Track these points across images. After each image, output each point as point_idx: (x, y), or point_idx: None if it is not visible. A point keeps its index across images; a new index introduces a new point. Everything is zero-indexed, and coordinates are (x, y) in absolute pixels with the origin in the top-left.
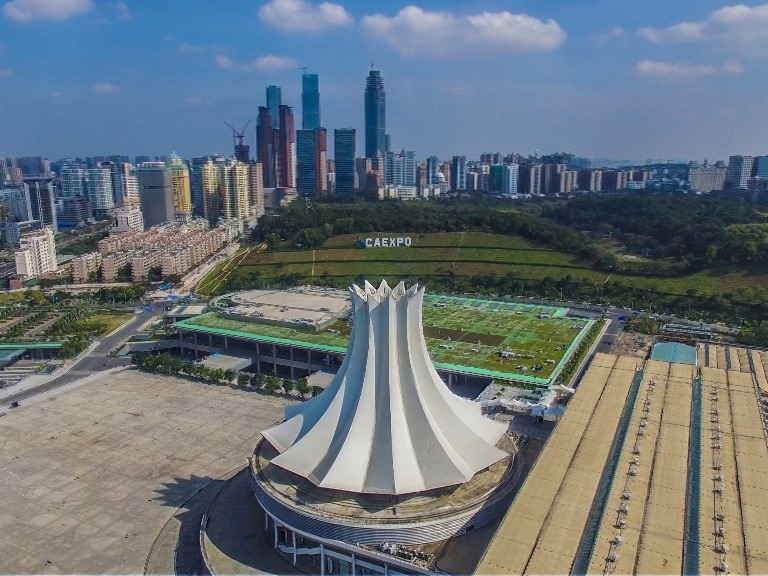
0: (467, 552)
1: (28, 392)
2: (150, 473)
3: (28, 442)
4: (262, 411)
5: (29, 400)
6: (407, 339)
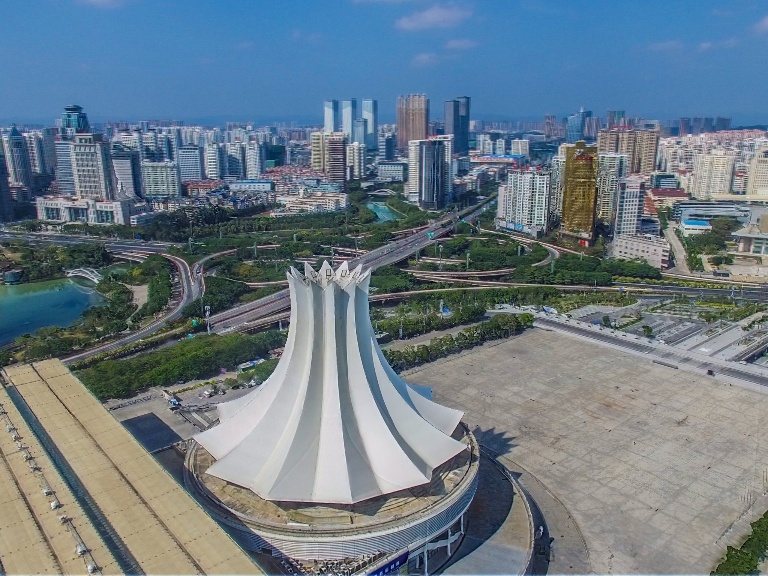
0: (169, 466)
1: (758, 378)
2: (530, 427)
3: (611, 380)
4: (699, 502)
5: (733, 379)
6: (291, 320)
